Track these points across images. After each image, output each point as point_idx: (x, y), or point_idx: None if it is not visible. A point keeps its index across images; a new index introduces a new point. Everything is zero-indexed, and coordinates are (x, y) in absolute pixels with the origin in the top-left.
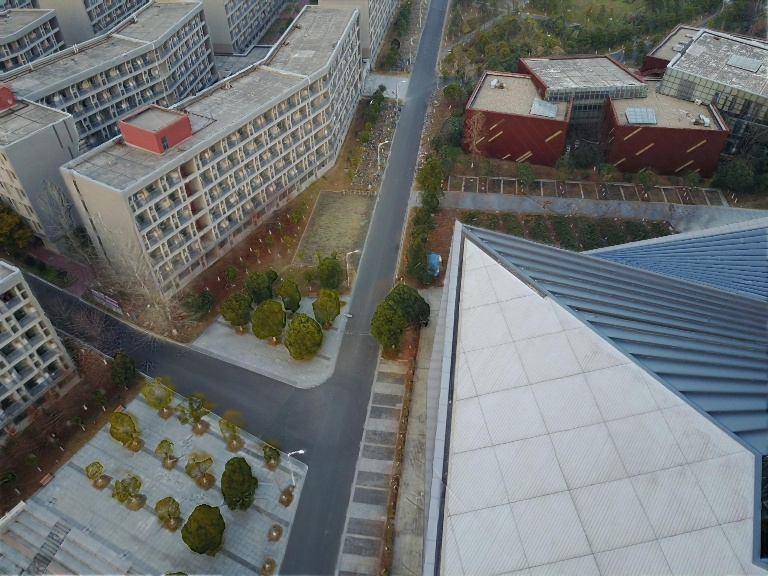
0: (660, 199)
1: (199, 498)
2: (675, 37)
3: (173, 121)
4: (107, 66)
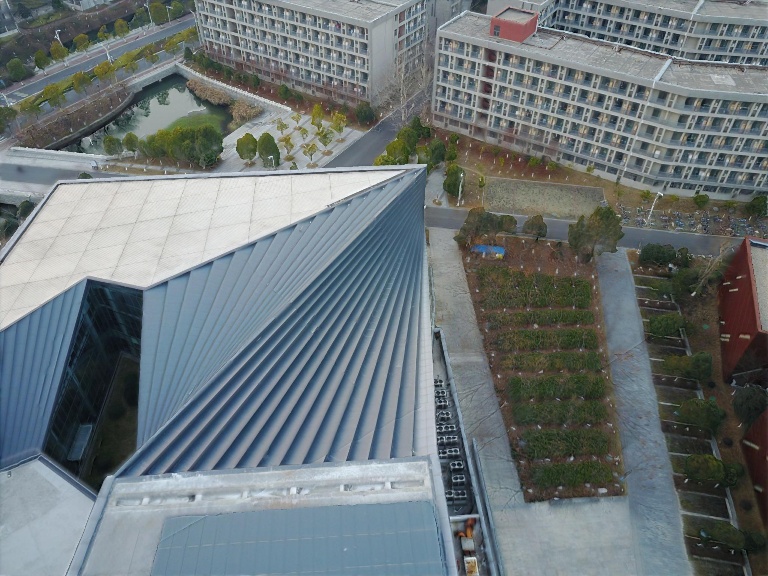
0: (689, 505)
1: None
2: None
3: (512, 21)
4: (638, 7)
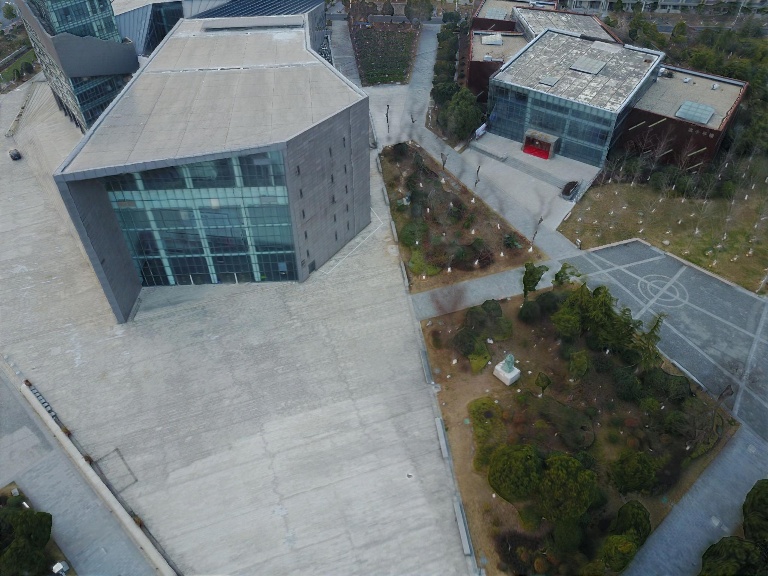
0: None
1: None
2: (707, 80)
3: None
4: None
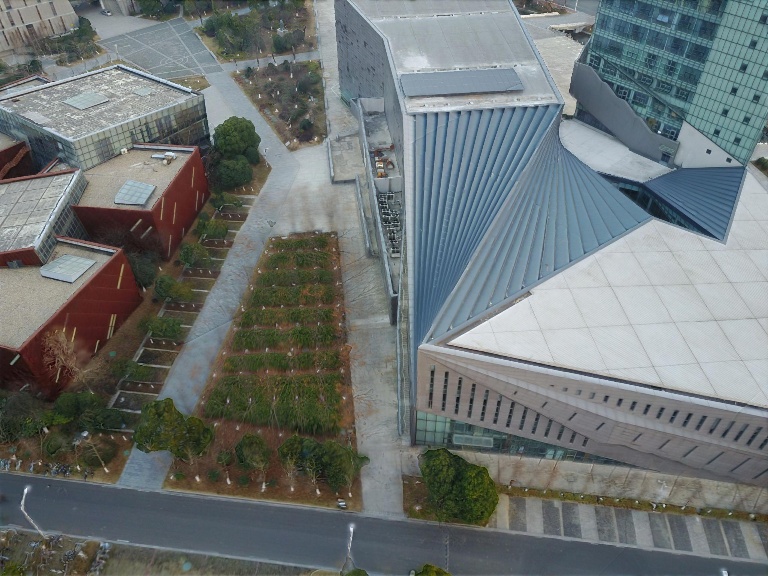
0: (231, 234)
1: None
2: None
3: None
4: None
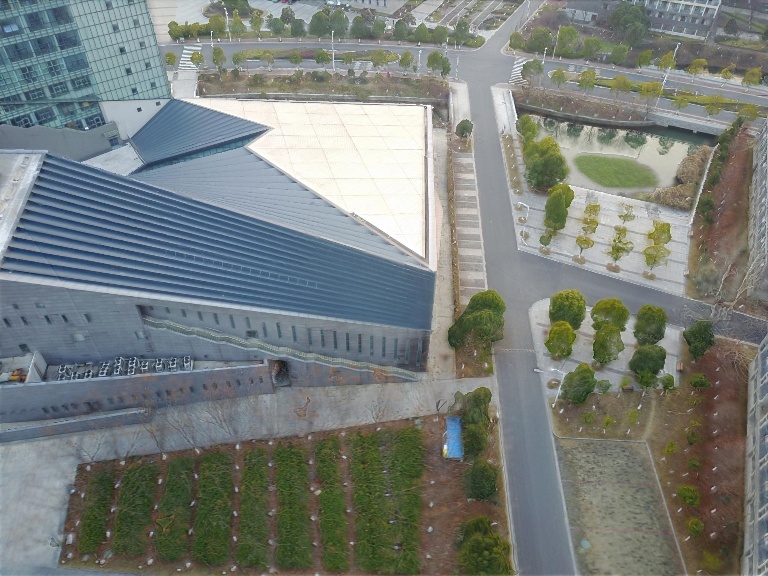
0: None
1: (582, 232)
2: None
3: None
4: None
